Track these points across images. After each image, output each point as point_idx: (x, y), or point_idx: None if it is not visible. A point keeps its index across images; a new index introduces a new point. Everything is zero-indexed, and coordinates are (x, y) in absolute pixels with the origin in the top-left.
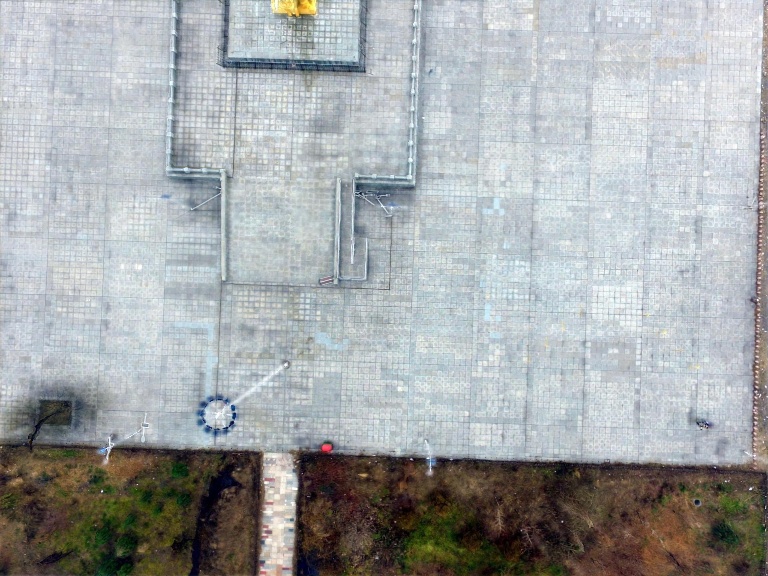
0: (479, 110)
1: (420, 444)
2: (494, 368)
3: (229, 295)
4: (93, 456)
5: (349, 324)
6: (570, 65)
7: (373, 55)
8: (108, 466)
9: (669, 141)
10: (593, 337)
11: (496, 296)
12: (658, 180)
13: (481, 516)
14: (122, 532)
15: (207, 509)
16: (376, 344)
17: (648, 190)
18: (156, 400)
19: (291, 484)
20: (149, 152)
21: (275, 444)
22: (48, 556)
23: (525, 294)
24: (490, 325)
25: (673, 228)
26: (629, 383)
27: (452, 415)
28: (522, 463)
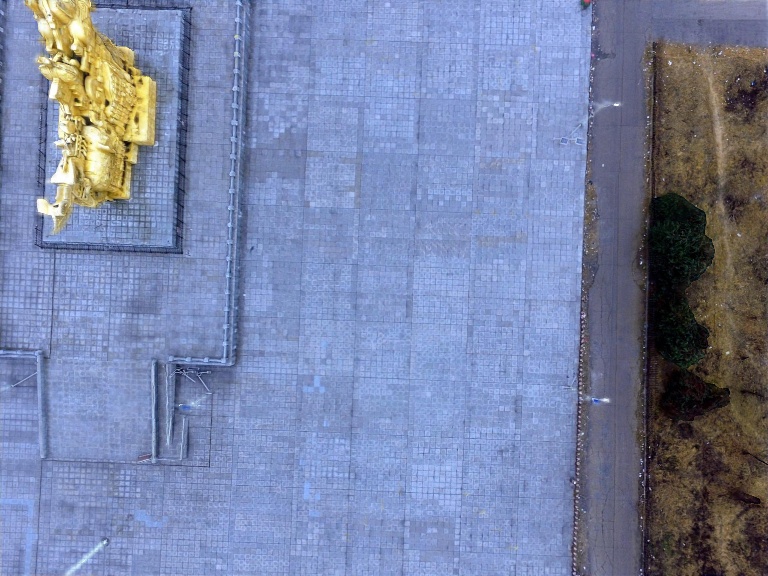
0: (300, 287)
1: None
2: (313, 547)
3: (49, 471)
4: None
5: (169, 501)
6: (391, 243)
7: (191, 236)
8: None
9: (490, 320)
10: (412, 516)
11: (316, 474)
12: (478, 359)
13: None
14: None
15: None
16: (195, 522)
17: (468, 369)
18: None
19: None
20: None
21: None
22: None
23: (345, 472)
24: (309, 503)
25: (493, 407)
26: (448, 563)
27: None
28: None
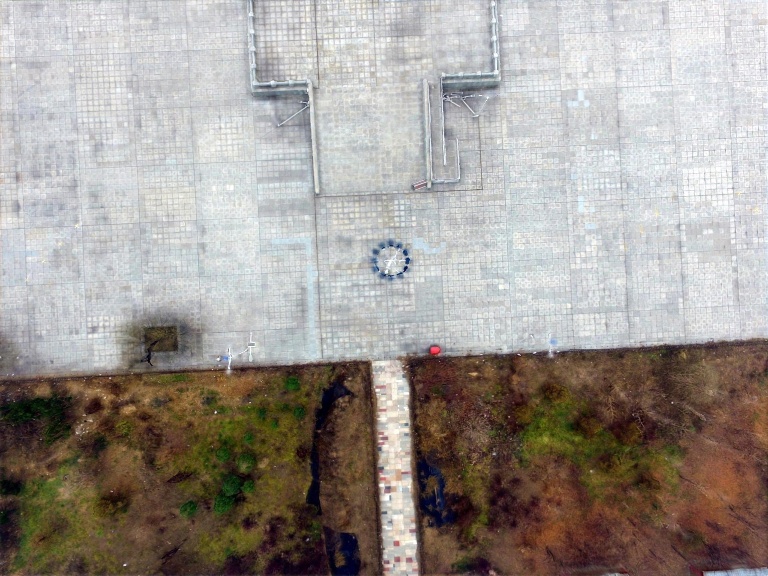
0: (556, 3)
1: (526, 339)
2: (592, 258)
3: (323, 208)
4: (203, 379)
5: (445, 227)
6: None
7: None
8: (219, 387)
9: (746, 19)
10: (687, 219)
11: (588, 187)
12: (738, 59)
13: (593, 404)
14: (239, 451)
15: (323, 420)
16: (474, 245)
17: (729, 70)
18: (260, 318)
19: (402, 389)
20: (230, 72)
21: (382, 352)
22: (172, 477)
23: (616, 183)
24: (585, 216)
25: (757, 105)
26: (726, 262)
27: (555, 308)
28: (628, 349)
